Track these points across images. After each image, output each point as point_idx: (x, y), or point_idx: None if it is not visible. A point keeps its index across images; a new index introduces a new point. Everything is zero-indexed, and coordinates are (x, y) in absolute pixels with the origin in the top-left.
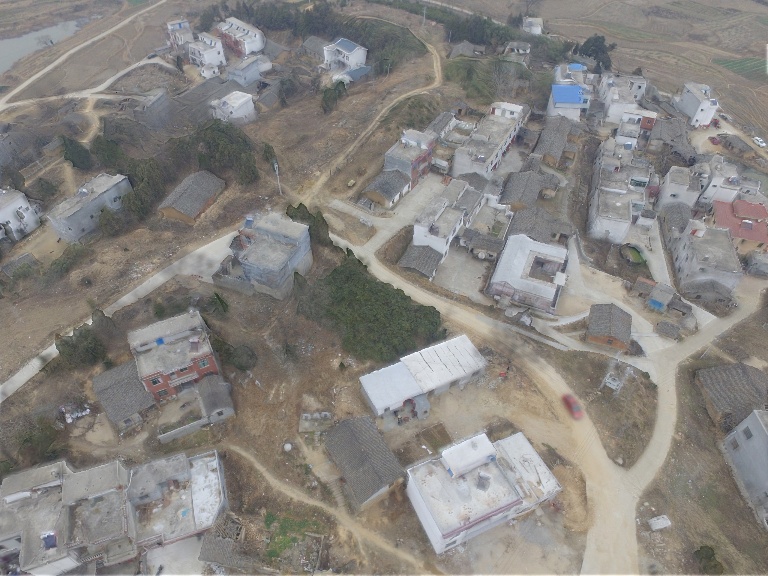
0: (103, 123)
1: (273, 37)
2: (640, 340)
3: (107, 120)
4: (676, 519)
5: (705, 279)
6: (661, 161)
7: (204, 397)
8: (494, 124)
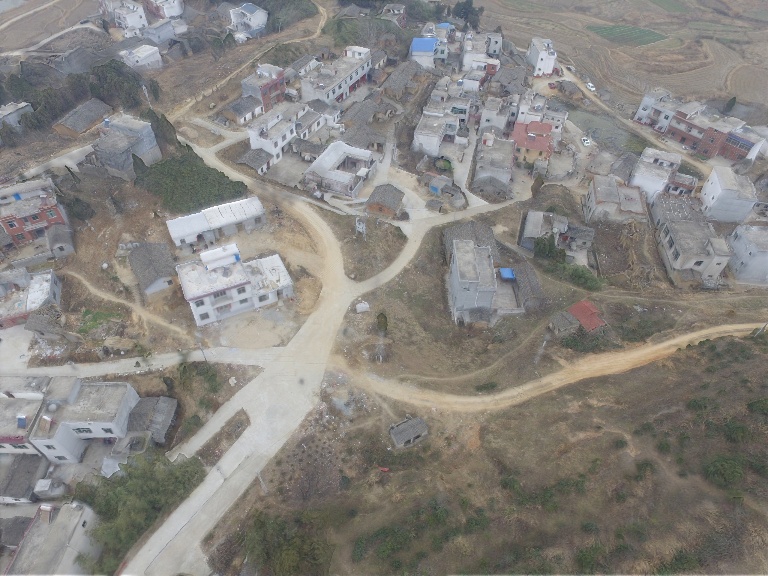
0: None
1: (194, 5)
2: (411, 212)
3: (23, 64)
4: (380, 309)
5: (486, 176)
6: None
7: (50, 238)
8: (344, 63)
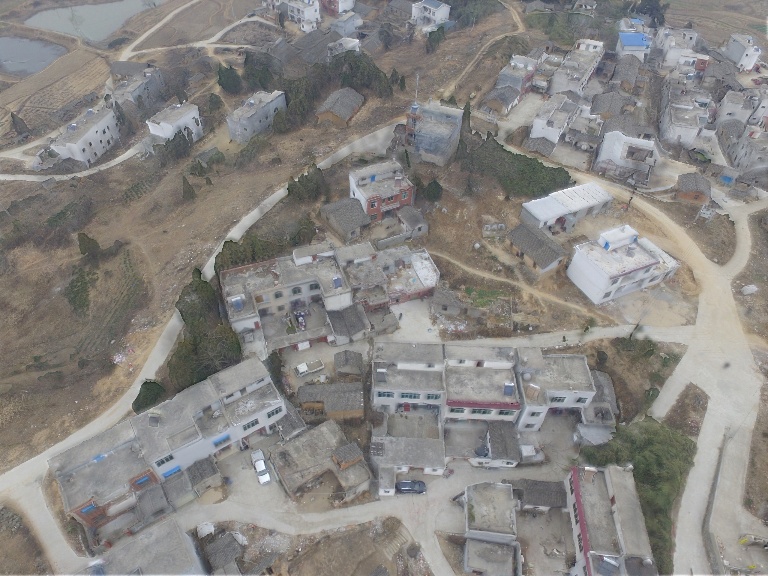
0: (228, 64)
1: None
2: (717, 201)
3: (249, 54)
4: (759, 291)
5: (762, 168)
6: (714, 93)
7: (406, 219)
8: (580, 56)
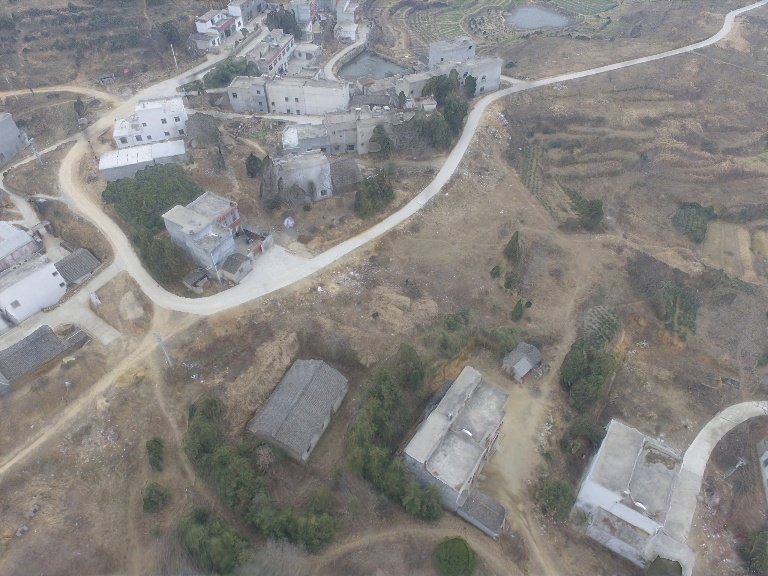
0: None
1: None
2: None
3: None
4: None
5: None
6: None
7: None
8: None
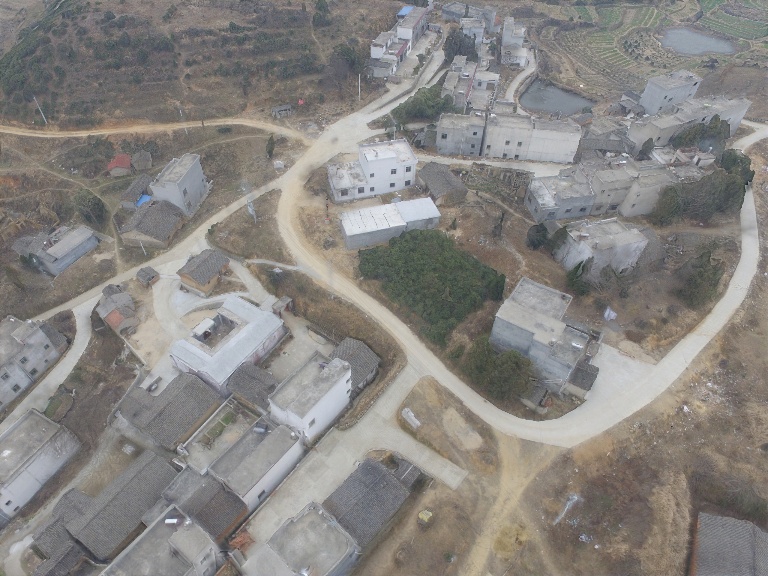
0: None
1: None
2: None
3: None
4: None
5: None
6: None
7: None
8: None
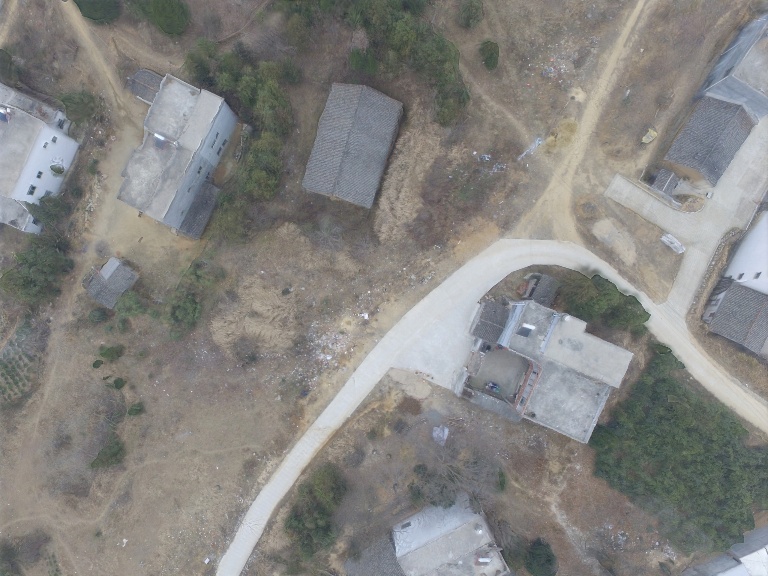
0: None
1: None
2: None
3: None
4: None
5: None
6: None
7: None
8: None
